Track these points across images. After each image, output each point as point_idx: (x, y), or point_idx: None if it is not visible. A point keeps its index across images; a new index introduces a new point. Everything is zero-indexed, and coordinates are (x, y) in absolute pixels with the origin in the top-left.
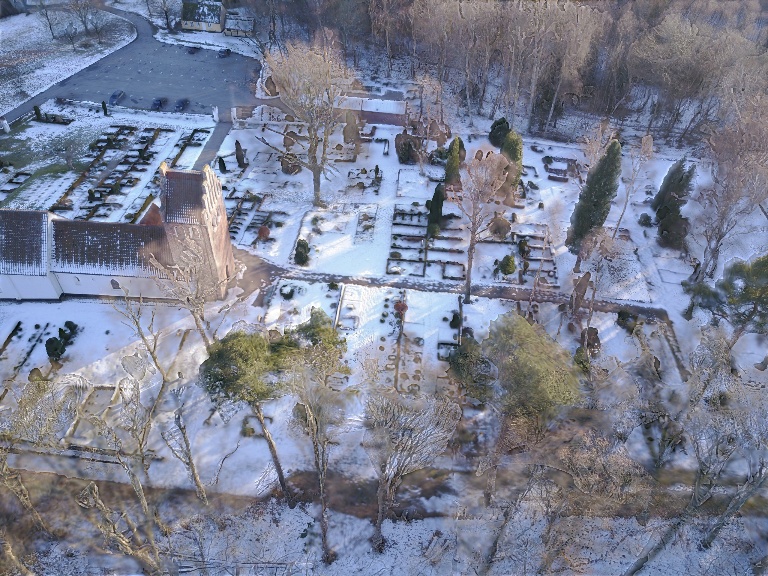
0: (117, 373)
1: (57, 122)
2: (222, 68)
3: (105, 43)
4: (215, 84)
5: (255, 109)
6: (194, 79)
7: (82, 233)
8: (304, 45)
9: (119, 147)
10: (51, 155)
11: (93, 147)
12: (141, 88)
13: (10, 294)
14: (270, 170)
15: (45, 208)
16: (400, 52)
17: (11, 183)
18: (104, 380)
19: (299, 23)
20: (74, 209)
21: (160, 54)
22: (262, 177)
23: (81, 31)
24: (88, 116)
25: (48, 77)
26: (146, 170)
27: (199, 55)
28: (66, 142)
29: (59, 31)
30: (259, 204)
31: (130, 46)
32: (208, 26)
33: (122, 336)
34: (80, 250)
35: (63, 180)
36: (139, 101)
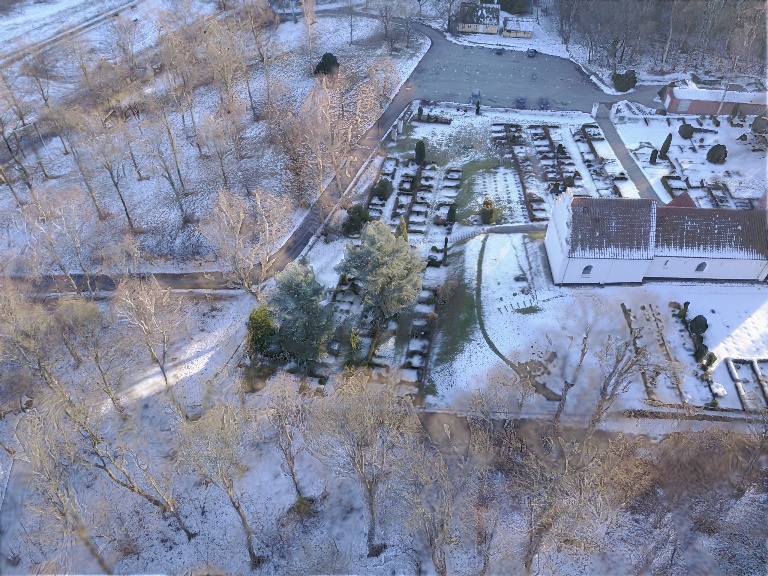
0: (759, 347)
1: (440, 122)
2: (542, 67)
3: (411, 47)
4: (553, 82)
5: (618, 105)
6: (528, 78)
7: (682, 219)
8: (588, 44)
9: (524, 143)
10: (462, 153)
11: (501, 144)
12: (486, 88)
13: (596, 279)
14: (696, 161)
15: (516, 201)
16: (687, 48)
17: (450, 179)
18: (753, 354)
19: (572, 23)
20: (546, 201)
21: (470, 56)
22: (697, 167)
23: (370, 36)
24: (461, 116)
25: (392, 80)
26: (574, 164)
27: (507, 56)
28: (464, 140)
29: (346, 37)
30: (730, 192)
31: (434, 49)
32: (485, 28)
33: (730, 314)
34: (679, 235)
35: (503, 175)
36: (497, 100)
